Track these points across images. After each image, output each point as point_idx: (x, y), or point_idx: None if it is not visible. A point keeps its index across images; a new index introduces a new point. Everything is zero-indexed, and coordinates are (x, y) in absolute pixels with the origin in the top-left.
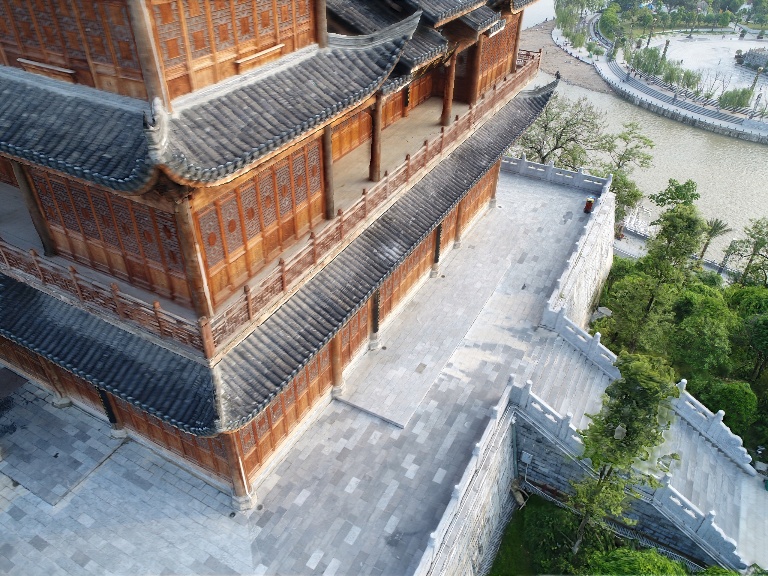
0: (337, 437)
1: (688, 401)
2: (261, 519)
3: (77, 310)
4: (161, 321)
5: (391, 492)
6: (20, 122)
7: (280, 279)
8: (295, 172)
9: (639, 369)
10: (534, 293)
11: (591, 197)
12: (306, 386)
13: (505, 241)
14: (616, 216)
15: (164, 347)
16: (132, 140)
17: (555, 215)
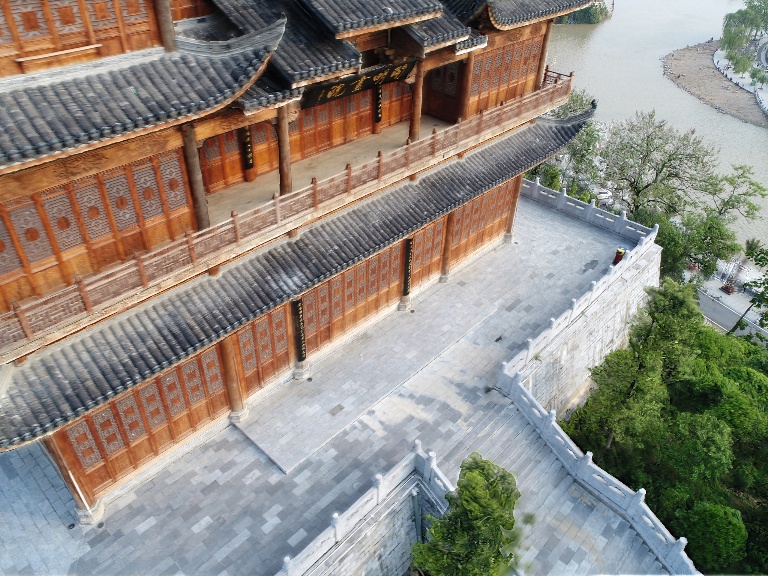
0: (214, 467)
1: (646, 516)
2: (95, 538)
3: None
4: None
5: (237, 543)
6: None
7: (81, 298)
8: (139, 184)
9: (469, 482)
10: (507, 348)
11: (623, 247)
12: (185, 407)
13: (503, 283)
14: (705, 269)
15: None
16: None
17: (576, 262)
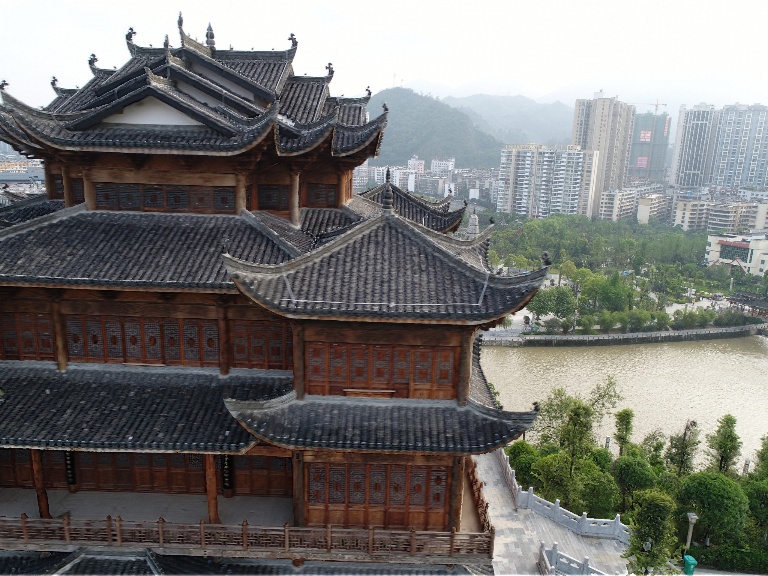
0: None
1: (624, 529)
2: None
3: (321, 574)
4: (454, 542)
5: None
6: (367, 428)
7: None
8: None
9: (654, 497)
10: (495, 486)
11: None
12: None
13: None
14: None
15: (449, 564)
16: (458, 423)
17: None
